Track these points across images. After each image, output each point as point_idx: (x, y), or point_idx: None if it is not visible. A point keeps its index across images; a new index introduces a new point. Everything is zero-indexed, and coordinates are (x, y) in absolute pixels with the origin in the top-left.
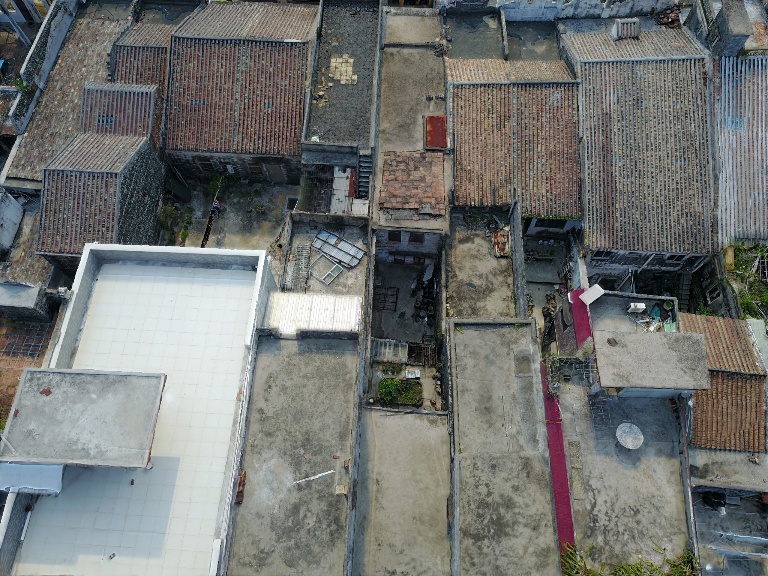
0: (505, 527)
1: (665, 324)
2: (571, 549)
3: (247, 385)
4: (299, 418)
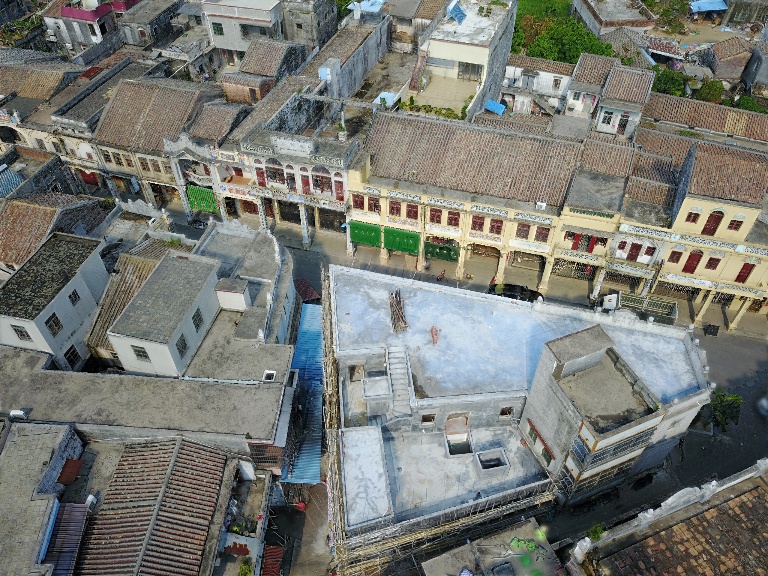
0: None
1: (74, 3)
2: None
3: None
4: None
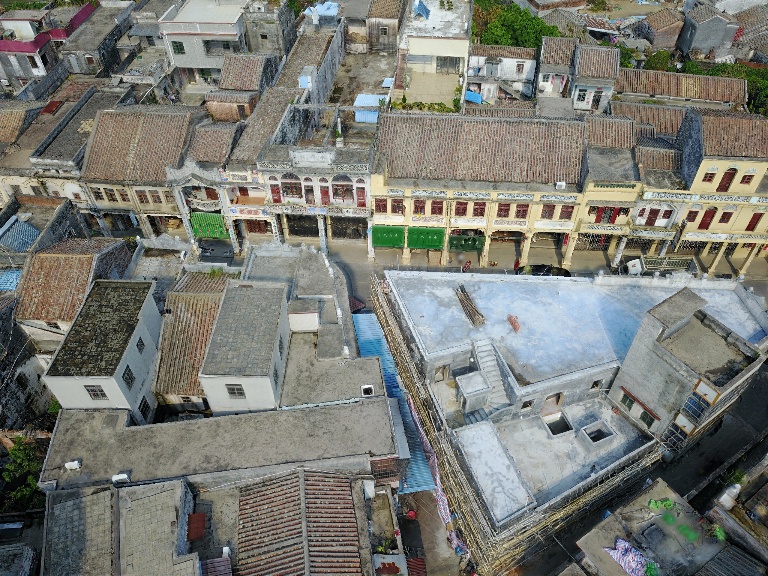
0: (111, 15)
1: (7, 35)
2: (91, 2)
3: (179, 3)
4: (165, 5)
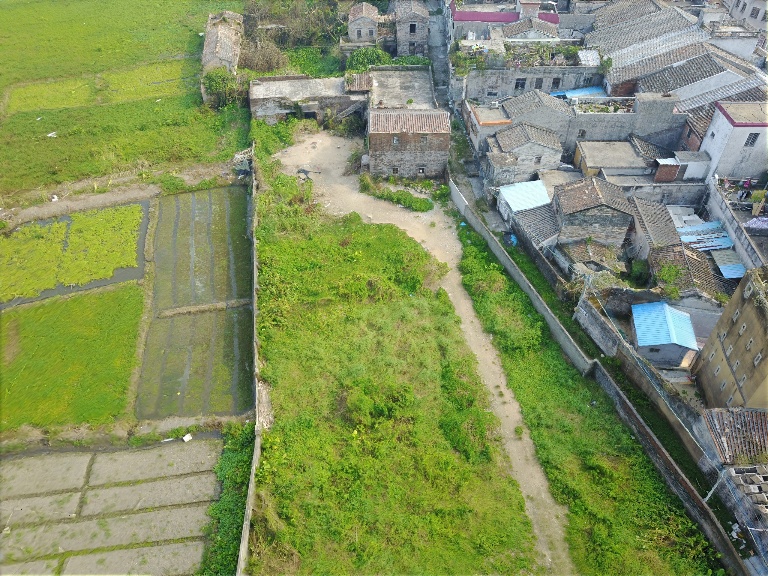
0: None
1: None
2: None
3: None
4: None
